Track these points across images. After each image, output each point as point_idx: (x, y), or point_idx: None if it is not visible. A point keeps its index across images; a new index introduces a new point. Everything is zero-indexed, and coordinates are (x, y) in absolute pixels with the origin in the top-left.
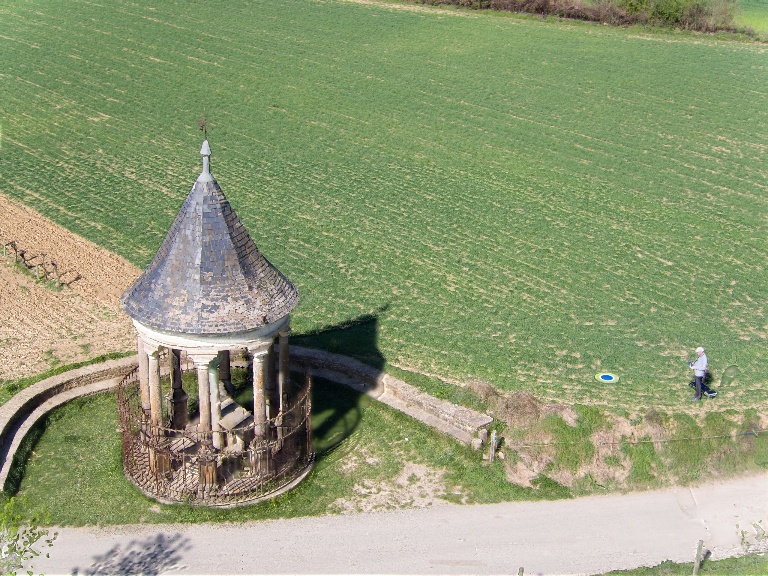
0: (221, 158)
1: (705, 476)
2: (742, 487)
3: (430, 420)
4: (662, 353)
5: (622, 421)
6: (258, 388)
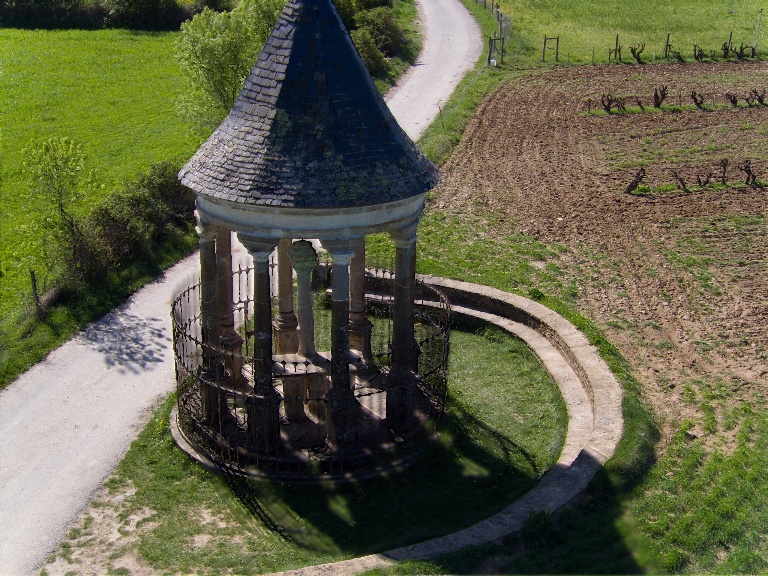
0: None
1: None
2: None
3: None
4: None
5: None
6: None
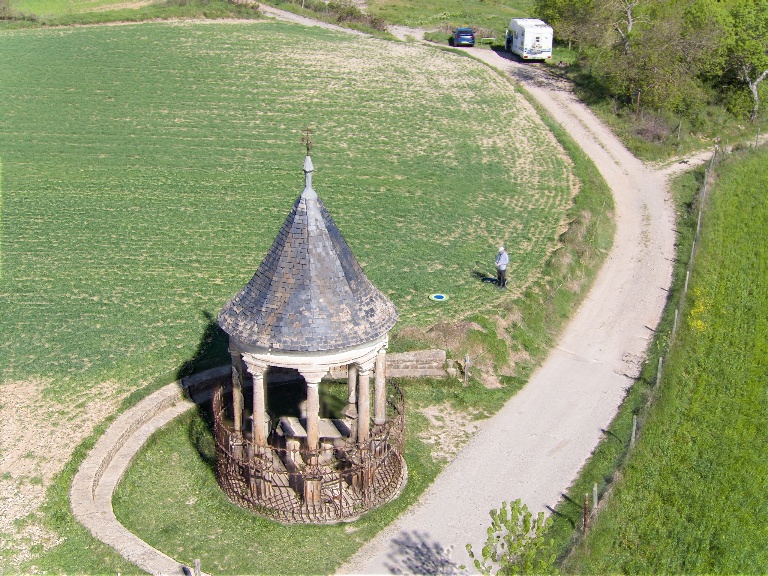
0: None
1: (552, 336)
2: (573, 334)
3: (396, 373)
4: (429, 271)
5: (499, 318)
6: (384, 378)
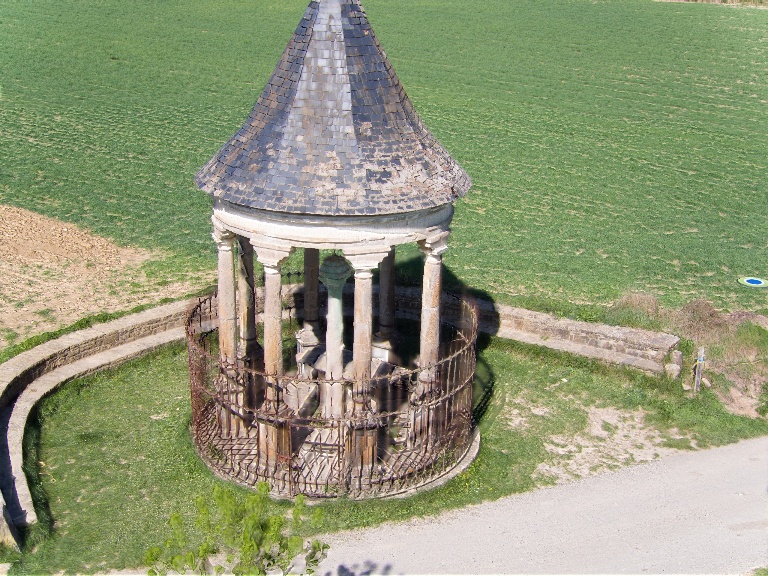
0: (83, 107)
1: None
2: None
3: (588, 351)
4: None
5: None
6: (433, 306)
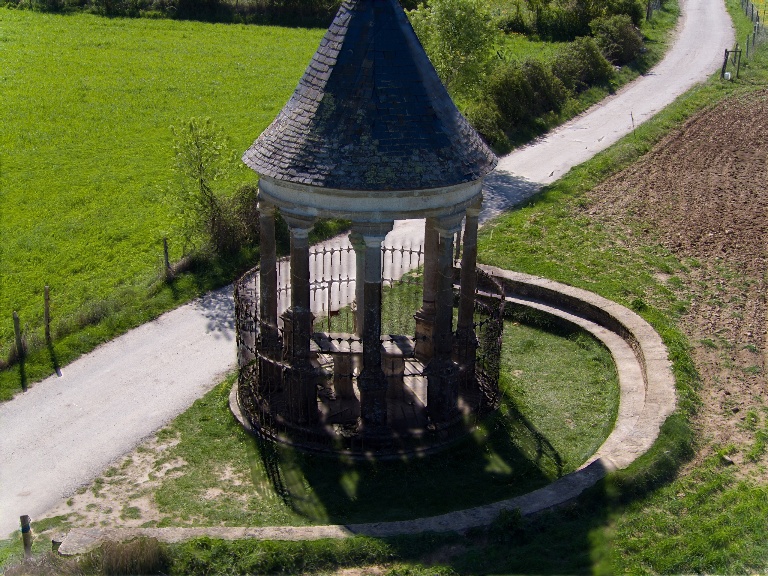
0: None
1: None
2: None
3: None
4: None
5: None
6: None
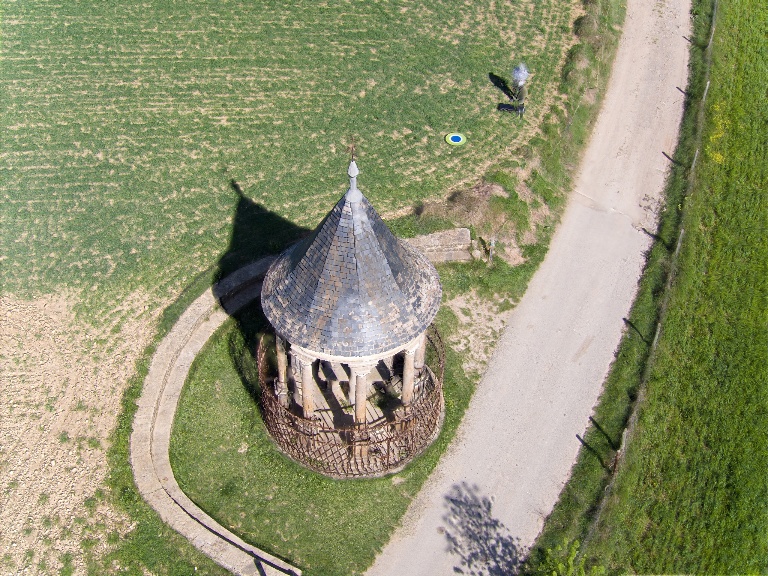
0: None
1: (569, 175)
2: (590, 168)
3: None
4: (442, 91)
5: (519, 171)
6: None
